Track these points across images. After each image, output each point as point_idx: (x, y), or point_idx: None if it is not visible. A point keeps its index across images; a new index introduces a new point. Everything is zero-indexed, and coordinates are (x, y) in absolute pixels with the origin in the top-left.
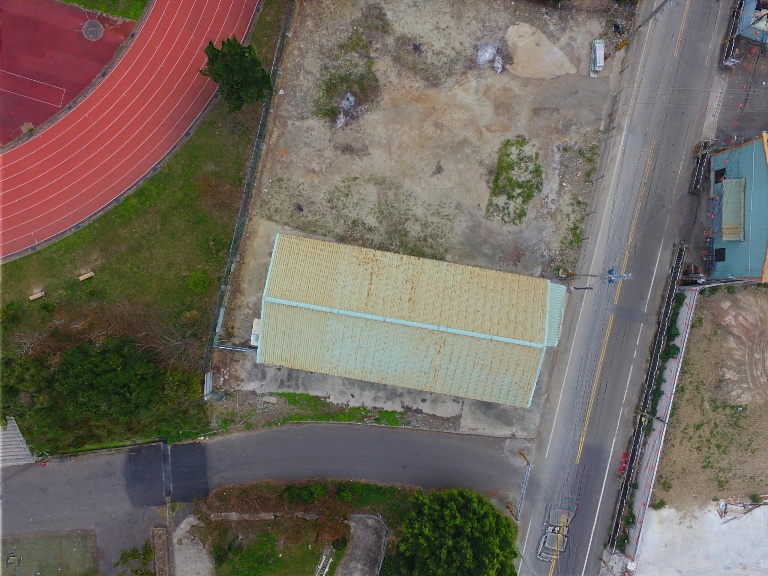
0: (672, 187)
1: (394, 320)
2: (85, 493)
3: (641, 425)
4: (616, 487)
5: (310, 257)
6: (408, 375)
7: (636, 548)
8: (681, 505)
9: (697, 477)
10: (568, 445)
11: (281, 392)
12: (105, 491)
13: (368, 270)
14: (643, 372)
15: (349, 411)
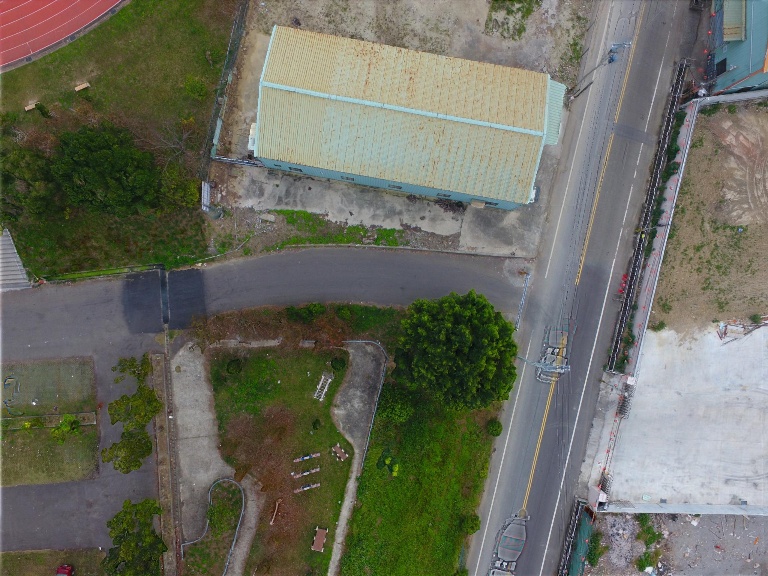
0: (673, 4)
1: (392, 107)
2: (83, 319)
3: (641, 242)
4: (616, 309)
5: (307, 48)
6: (407, 169)
7: (636, 363)
8: (681, 327)
9: (697, 299)
10: (568, 266)
11: (279, 209)
12: (103, 317)
13: (366, 61)
14: (643, 193)
15: (347, 230)
